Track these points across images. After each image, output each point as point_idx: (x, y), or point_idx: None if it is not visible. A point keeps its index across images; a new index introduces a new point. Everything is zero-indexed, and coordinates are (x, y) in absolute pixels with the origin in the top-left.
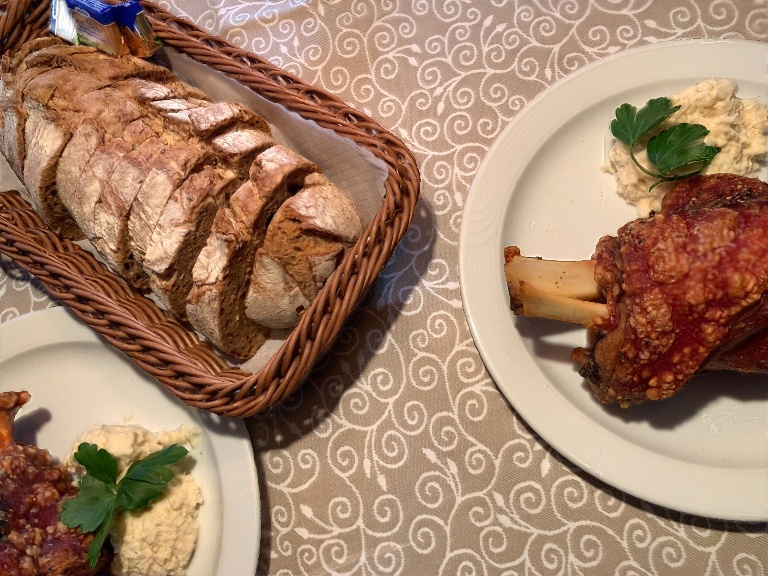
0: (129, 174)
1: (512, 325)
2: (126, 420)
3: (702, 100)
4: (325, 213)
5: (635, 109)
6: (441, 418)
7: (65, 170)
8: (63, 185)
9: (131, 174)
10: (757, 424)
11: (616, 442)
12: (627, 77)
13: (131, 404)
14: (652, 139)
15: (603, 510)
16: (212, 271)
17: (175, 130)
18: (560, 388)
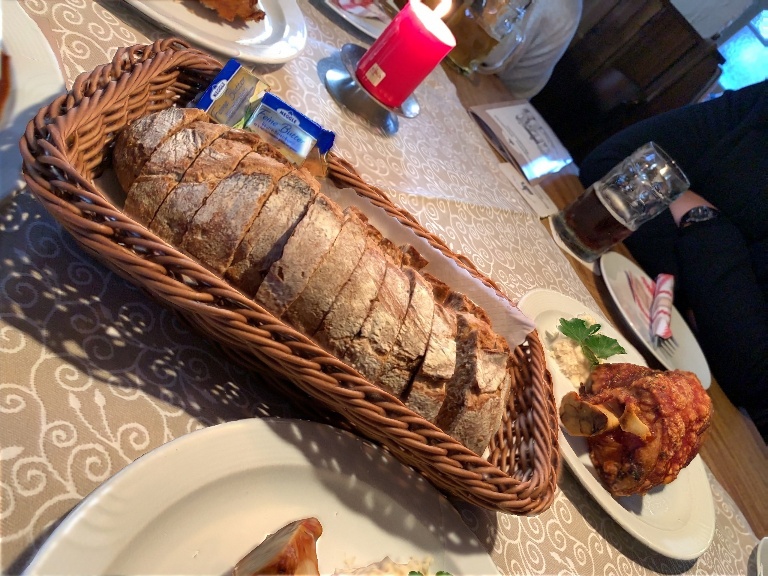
0: (398, 281)
1: (571, 448)
2: (349, 564)
3: (590, 324)
4: None
5: (569, 322)
6: (551, 525)
7: (336, 260)
8: (328, 274)
9: (400, 282)
10: (660, 507)
11: (640, 522)
12: (544, 303)
13: (347, 543)
14: (586, 340)
15: (640, 575)
16: (492, 381)
17: (391, 254)
18: (605, 490)
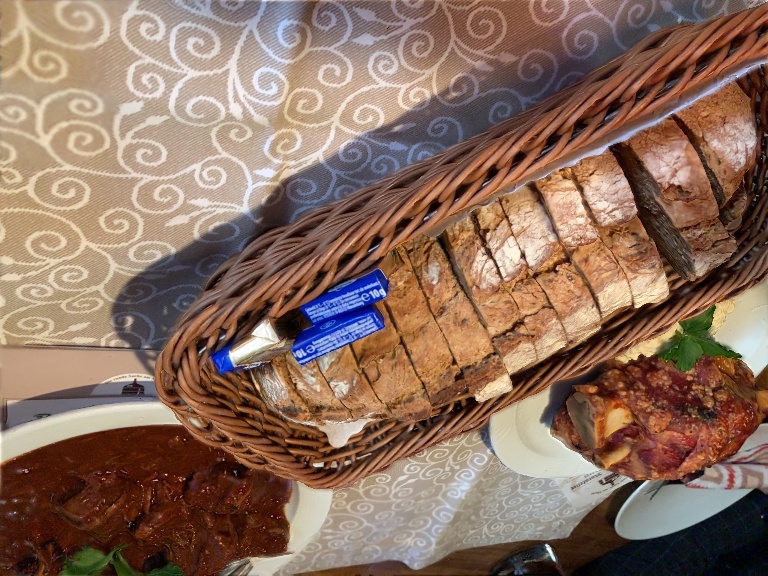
0: (579, 316)
1: None
2: None
3: None
4: (741, 130)
5: None
6: None
7: None
8: None
9: (581, 315)
10: None
11: None
12: None
13: None
14: None
15: None
16: None
17: None
18: None
